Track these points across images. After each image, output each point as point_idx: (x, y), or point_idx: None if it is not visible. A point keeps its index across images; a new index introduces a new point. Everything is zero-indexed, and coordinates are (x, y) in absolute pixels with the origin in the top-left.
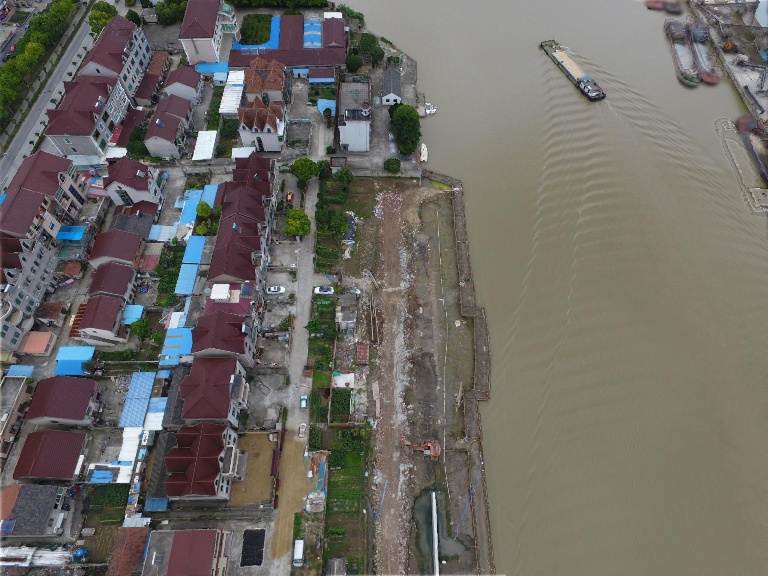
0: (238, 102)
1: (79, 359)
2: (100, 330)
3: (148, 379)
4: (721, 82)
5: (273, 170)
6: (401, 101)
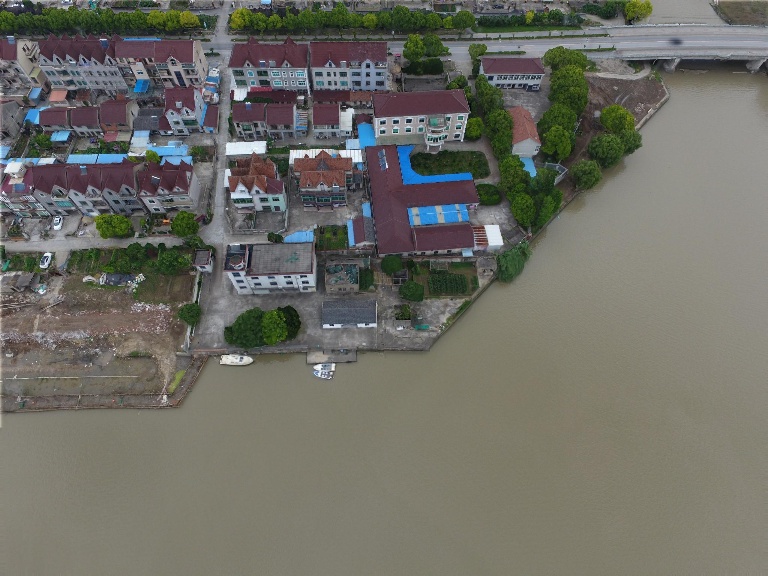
0: None
1: (37, 118)
2: None
3: (1, 155)
4: None
5: (174, 194)
6: (332, 329)
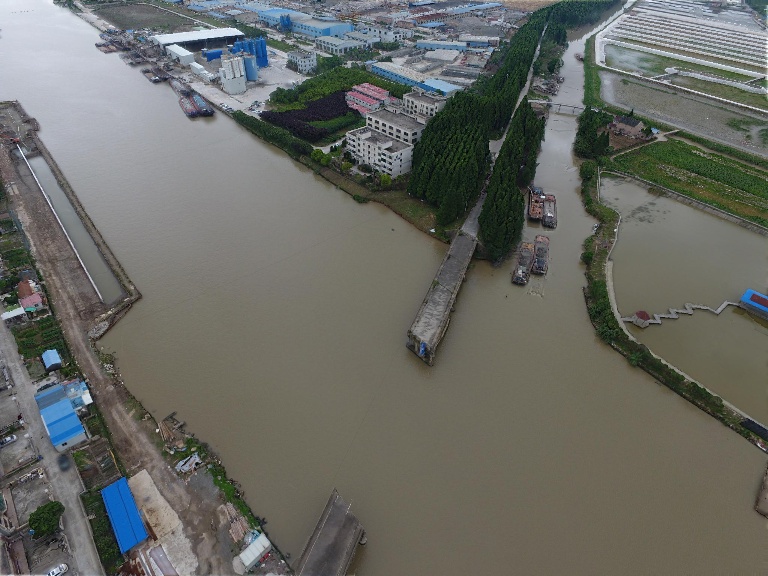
0: None
1: None
2: None
3: None
4: (142, 62)
5: None
6: None
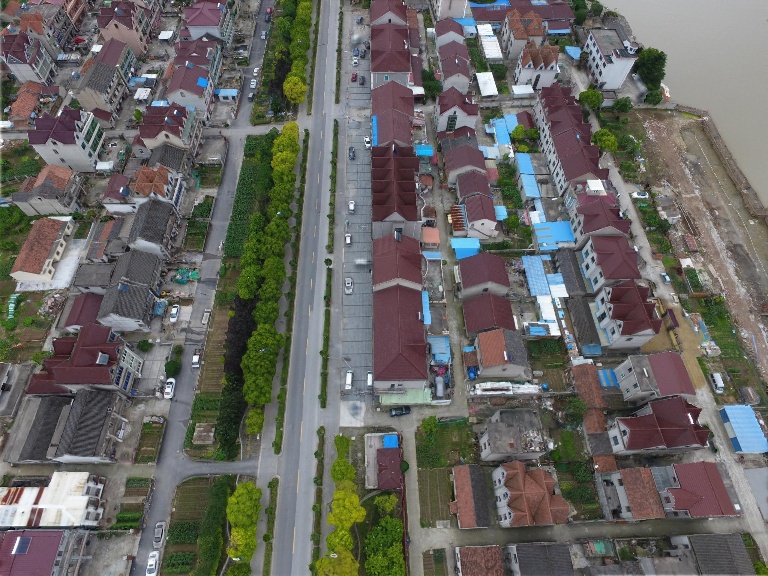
0: (499, 49)
1: (471, 247)
2: (490, 222)
3: (536, 261)
4: None
5: None
6: None
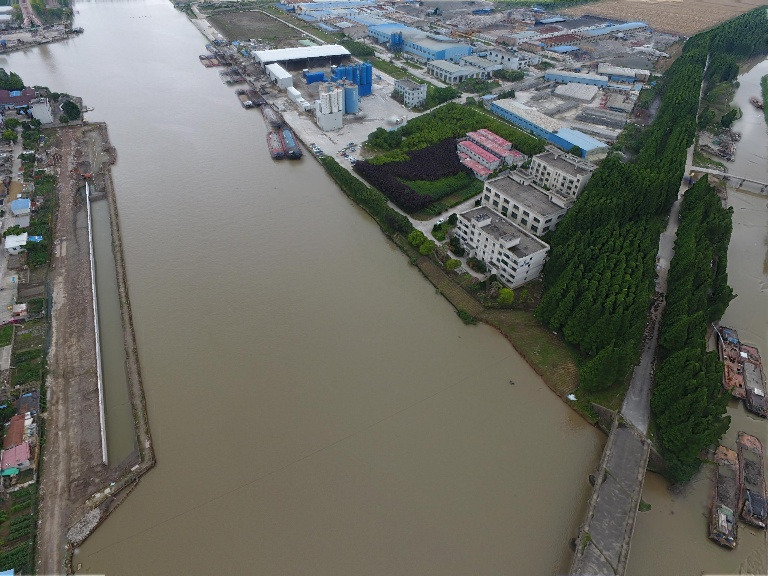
0: None
1: None
2: None
3: None
4: (239, 81)
5: None
6: None
